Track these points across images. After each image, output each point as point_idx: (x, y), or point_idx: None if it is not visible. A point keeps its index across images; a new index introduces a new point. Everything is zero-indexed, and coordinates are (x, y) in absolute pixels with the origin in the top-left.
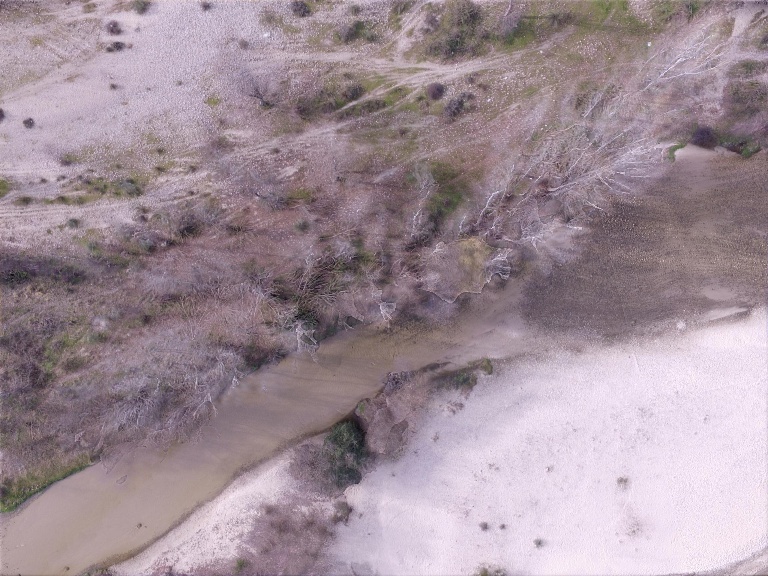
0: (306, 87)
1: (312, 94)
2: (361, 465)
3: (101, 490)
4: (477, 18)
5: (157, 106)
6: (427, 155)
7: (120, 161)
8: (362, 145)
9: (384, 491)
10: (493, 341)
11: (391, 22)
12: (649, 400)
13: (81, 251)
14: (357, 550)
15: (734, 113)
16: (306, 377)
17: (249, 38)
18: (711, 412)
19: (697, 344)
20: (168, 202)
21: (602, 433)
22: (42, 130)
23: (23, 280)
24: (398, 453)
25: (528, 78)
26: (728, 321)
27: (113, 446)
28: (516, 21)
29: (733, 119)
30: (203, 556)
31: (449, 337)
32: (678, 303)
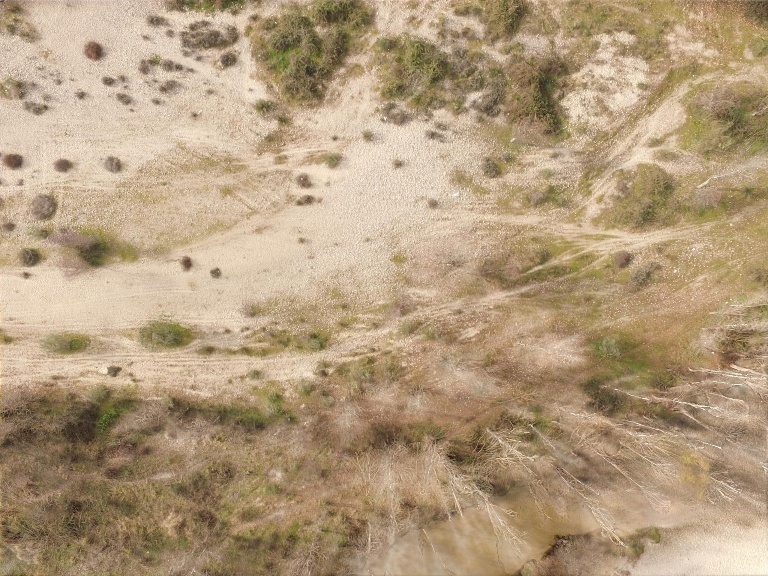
0: (492, 249)
1: (498, 257)
2: None
3: None
4: (669, 188)
5: (343, 262)
6: (609, 323)
7: (304, 315)
8: (545, 310)
9: None
10: None
11: (581, 187)
12: None
13: (261, 402)
14: None
15: None
16: (474, 535)
17: (438, 197)
18: None
19: None
20: (349, 358)
21: None
22: (228, 280)
23: (203, 428)
24: None
25: (716, 250)
26: None
27: None
28: (717, 202)
29: None
30: None
31: (618, 503)
32: None
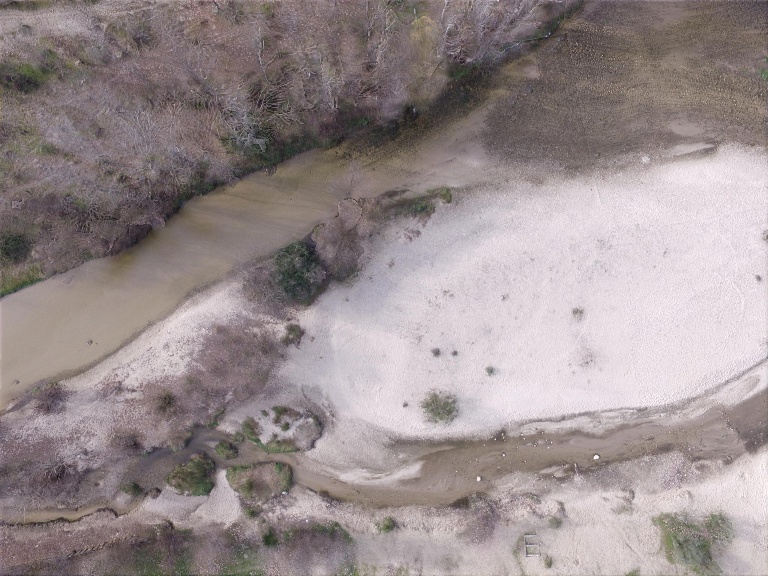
0: None
1: None
2: (311, 272)
3: (52, 305)
4: None
5: None
6: None
7: None
8: None
9: (337, 316)
10: (453, 170)
11: None
12: (609, 232)
13: (35, 59)
14: (308, 373)
15: None
16: (262, 200)
17: None
18: (671, 246)
19: (661, 179)
20: (124, 12)
21: (560, 263)
22: None
23: None
24: (353, 279)
25: None
26: (694, 157)
27: (56, 232)
28: None
29: None
30: (153, 372)
31: (409, 165)
32: (644, 137)
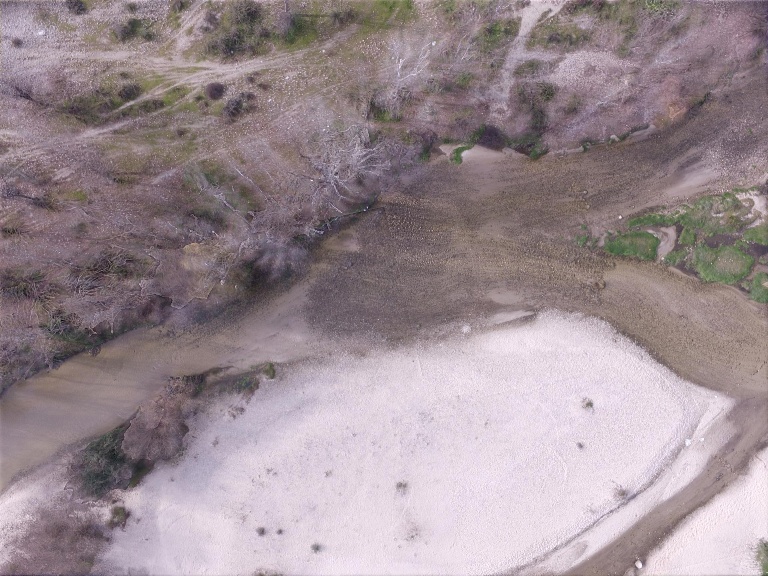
0: (82, 86)
1: (88, 94)
2: (117, 471)
3: None
4: (257, 16)
5: None
6: (207, 156)
7: None
8: (140, 146)
9: (163, 496)
10: (276, 345)
11: (170, 20)
12: (430, 405)
13: None
14: (134, 556)
15: (520, 114)
16: (86, 381)
17: (23, 36)
18: (492, 417)
19: (482, 348)
20: None
21: (382, 438)
22: None
23: None
24: (178, 458)
25: (310, 78)
26: (514, 325)
27: None
28: (286, 20)
29: (519, 120)
30: None
31: (232, 341)
32: (464, 307)
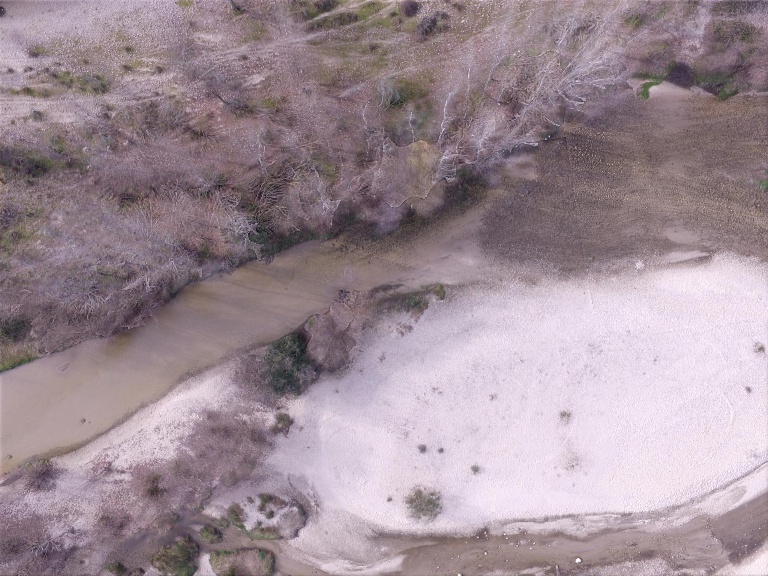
0: None
1: (284, 2)
2: (301, 371)
3: (48, 383)
4: None
5: (128, 3)
6: (396, 73)
7: (88, 56)
8: (331, 58)
9: (327, 406)
10: (448, 267)
11: None
12: (600, 337)
13: (43, 144)
14: (295, 462)
15: (713, 52)
16: (258, 288)
17: None
18: (662, 354)
19: (654, 285)
20: (133, 101)
21: (549, 366)
22: (12, 19)
23: None
24: (344, 370)
25: (505, 1)
26: (688, 265)
27: (54, 327)
28: None
29: (712, 58)
30: (143, 455)
31: (404, 260)
32: (639, 243)
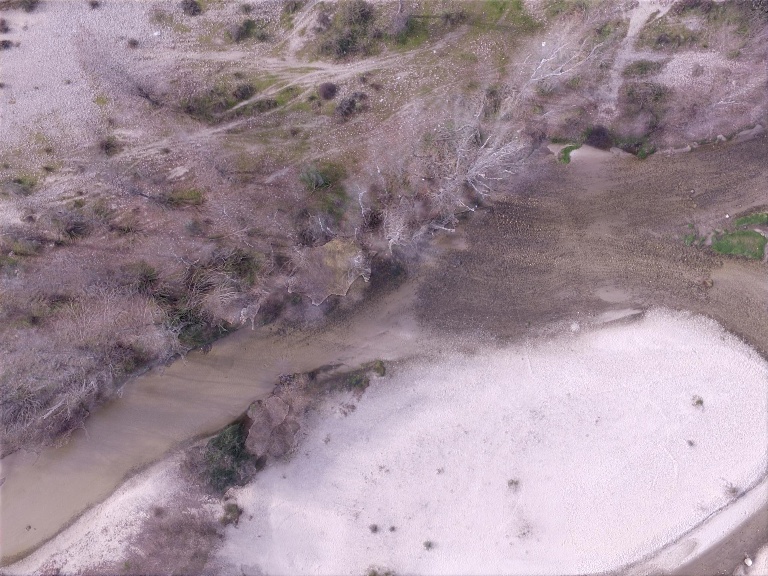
0: (196, 86)
1: (202, 94)
2: (241, 468)
3: None
4: (370, 17)
5: (45, 105)
6: (319, 155)
7: (8, 161)
8: (253, 145)
9: (275, 493)
10: (386, 343)
11: (283, 21)
12: (541, 402)
13: None
14: (247, 552)
15: (629, 114)
16: (198, 379)
17: (139, 37)
18: (603, 414)
19: (591, 346)
20: (57, 202)
21: (493, 435)
22: None
23: None
24: (290, 455)
25: (421, 78)
26: (622, 323)
27: None
28: (403, 20)
29: (628, 120)
30: (91, 558)
31: (342, 339)
32: (572, 305)
